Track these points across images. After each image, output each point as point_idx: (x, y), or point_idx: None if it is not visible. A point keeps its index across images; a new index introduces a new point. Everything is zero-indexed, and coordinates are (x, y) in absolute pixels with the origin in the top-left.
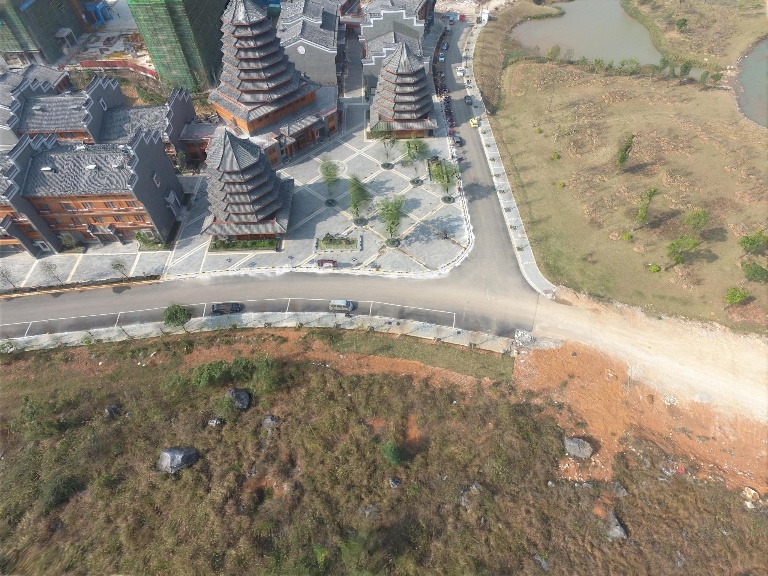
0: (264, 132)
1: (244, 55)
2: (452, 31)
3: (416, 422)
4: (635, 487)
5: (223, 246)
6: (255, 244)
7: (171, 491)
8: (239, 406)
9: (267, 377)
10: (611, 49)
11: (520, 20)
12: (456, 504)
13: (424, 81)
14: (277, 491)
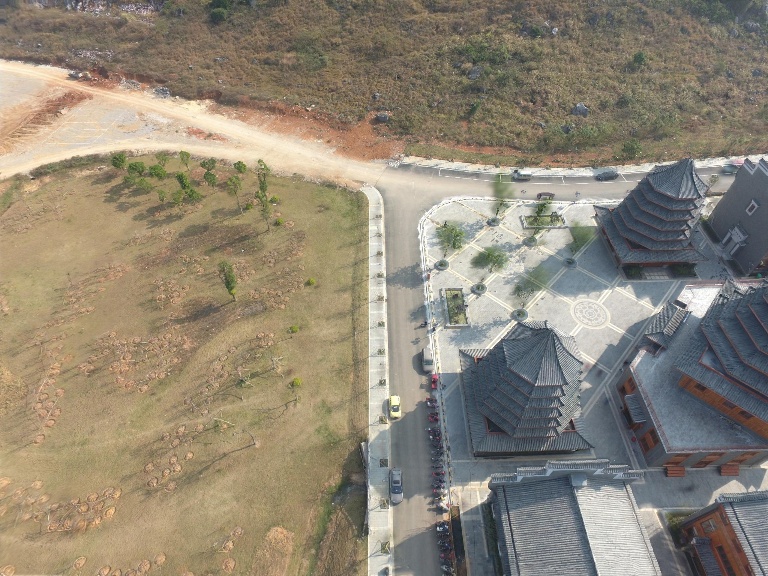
0: None
1: None
2: None
3: (463, 127)
4: None
5: None
6: None
7: (574, 101)
8: None
9: None
10: None
11: None
12: None
13: None
14: None
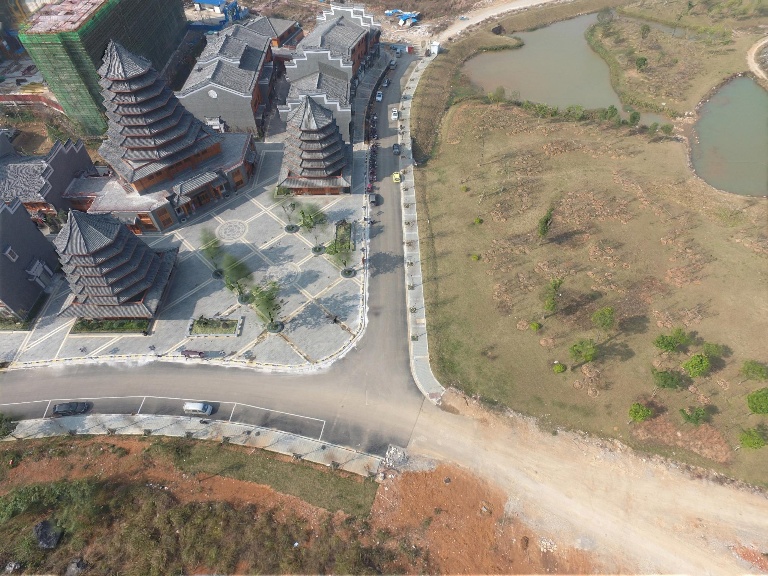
0: (157, 190)
1: (124, 111)
2: (397, 65)
3: (245, 572)
4: None
5: (87, 327)
6: (123, 325)
7: None
8: (44, 547)
9: (80, 511)
10: (565, 88)
11: (475, 52)
12: None
13: (334, 136)
14: None
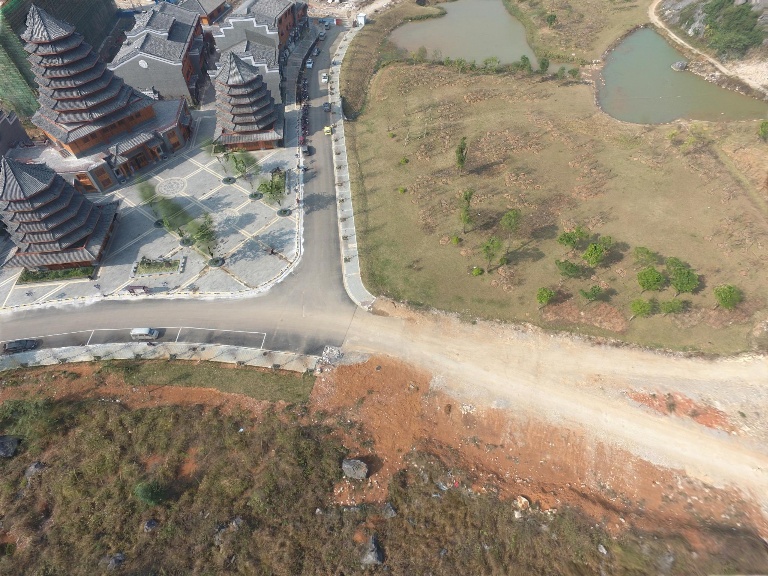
0: (94, 153)
1: (53, 74)
2: (326, 36)
3: (194, 456)
4: (406, 506)
5: (32, 278)
6: (68, 273)
7: None
8: (2, 455)
9: (34, 421)
10: (485, 48)
11: (401, 22)
12: (209, 544)
13: (262, 91)
14: (19, 548)
